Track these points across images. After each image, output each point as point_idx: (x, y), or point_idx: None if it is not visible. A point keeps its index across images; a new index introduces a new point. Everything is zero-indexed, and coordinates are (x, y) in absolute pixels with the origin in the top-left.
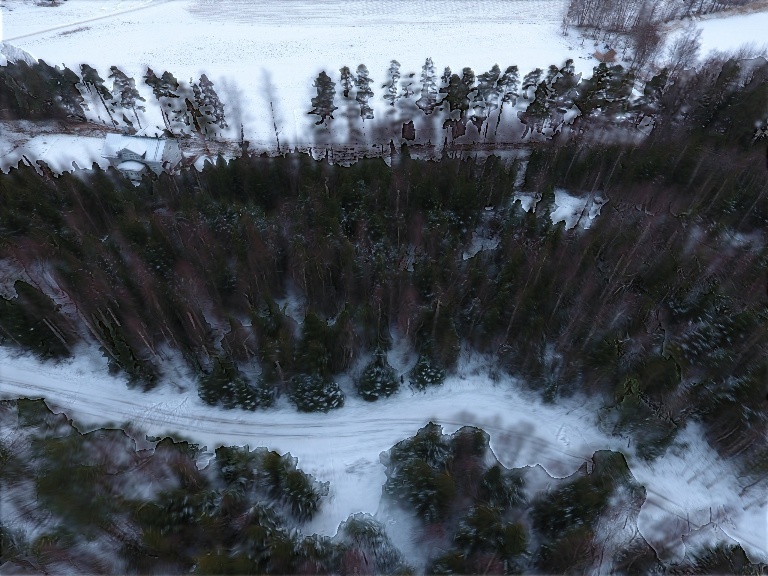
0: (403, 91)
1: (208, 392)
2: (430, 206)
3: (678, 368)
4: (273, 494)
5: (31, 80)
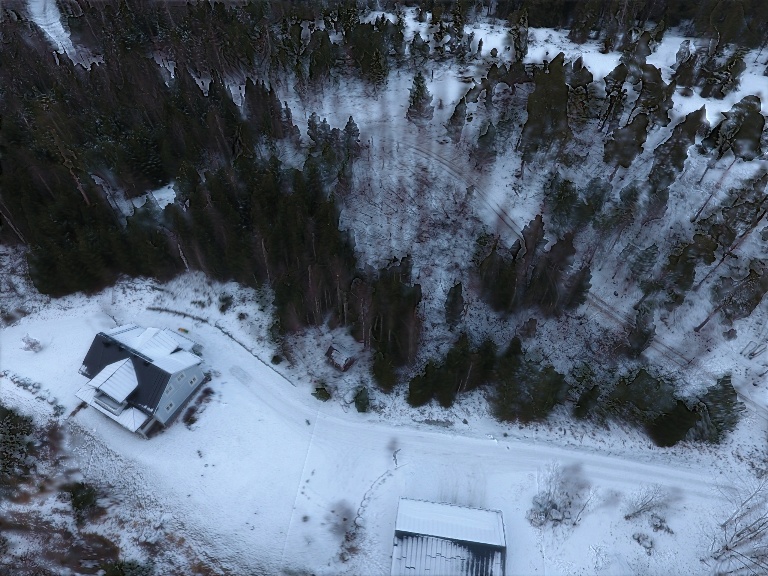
0: None
1: None
2: None
3: None
4: None
5: None
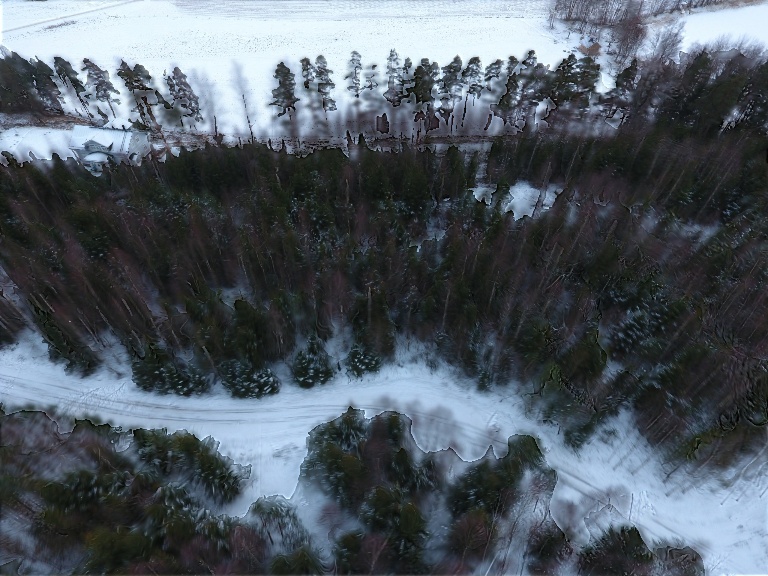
0: (384, 85)
1: (141, 377)
2: (381, 196)
3: (603, 355)
4: (186, 475)
5: (2, 72)
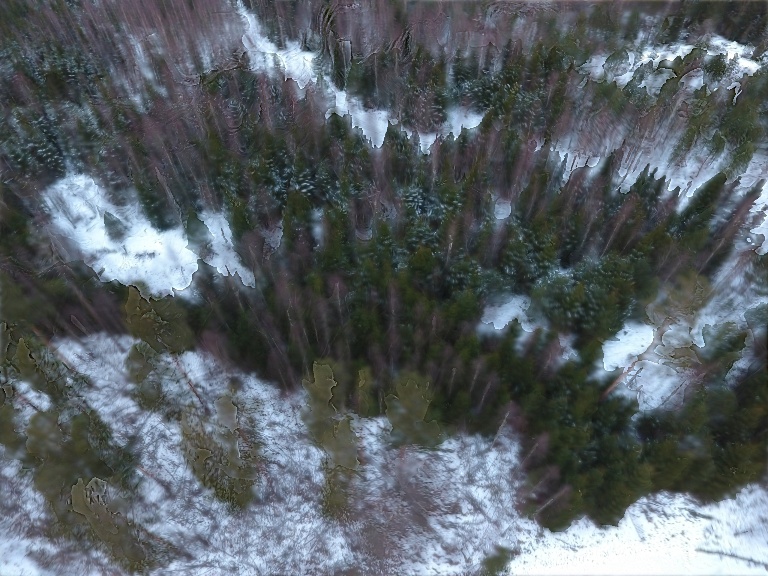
0: None
1: None
2: None
3: None
4: None
5: None
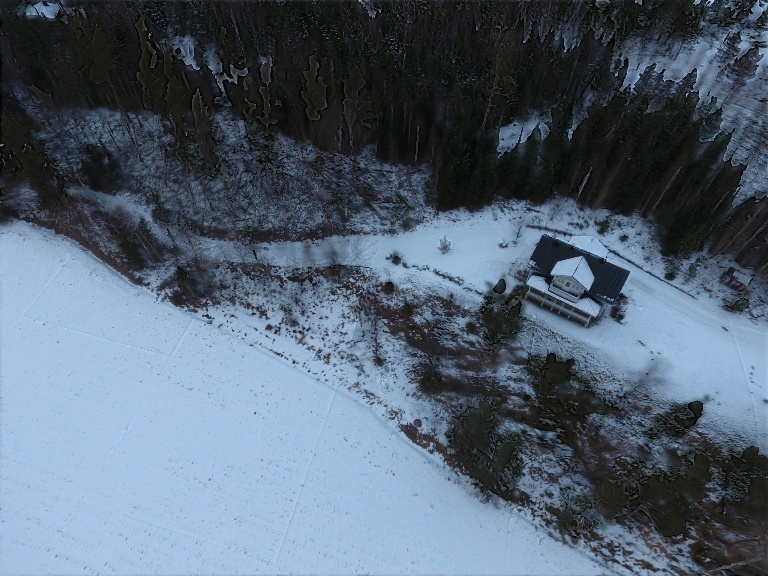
0: None
1: None
2: None
3: None
4: None
5: None
